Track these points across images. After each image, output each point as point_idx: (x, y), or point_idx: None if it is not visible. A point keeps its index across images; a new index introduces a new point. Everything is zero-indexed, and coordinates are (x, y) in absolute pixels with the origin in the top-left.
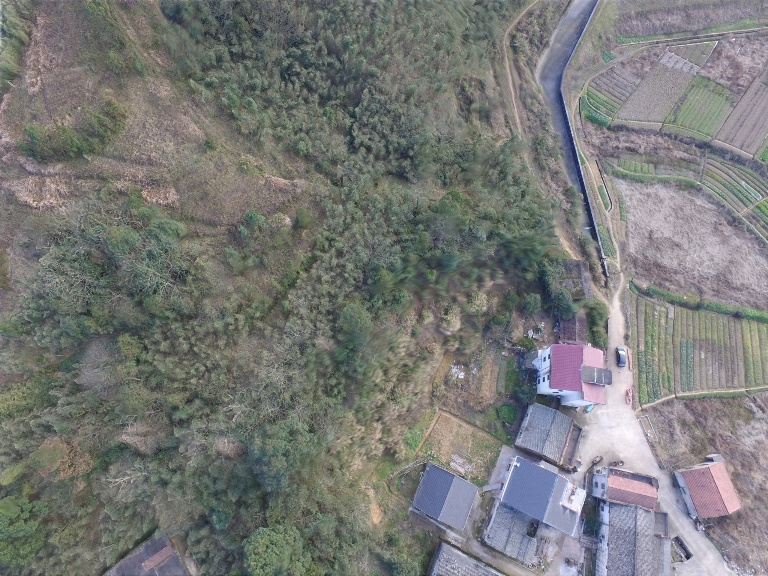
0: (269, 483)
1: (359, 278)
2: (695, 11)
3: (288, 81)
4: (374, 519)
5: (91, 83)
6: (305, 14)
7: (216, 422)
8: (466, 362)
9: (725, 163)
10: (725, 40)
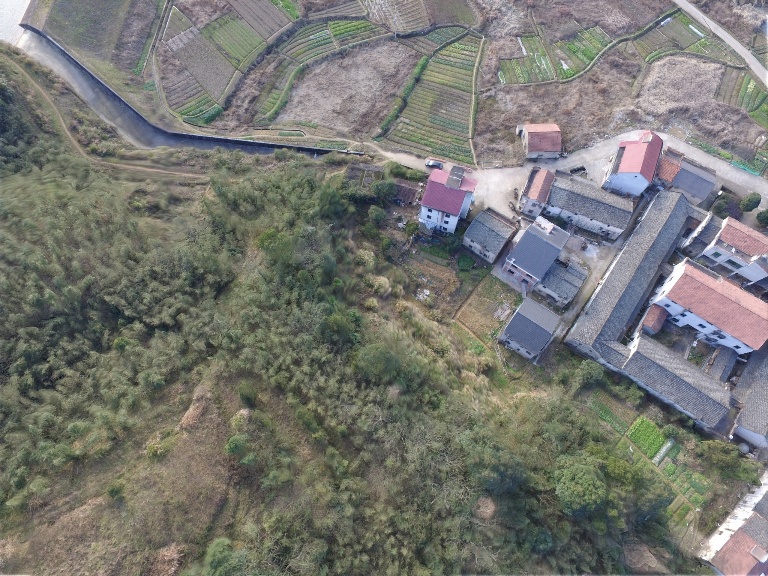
0: (520, 474)
1: (328, 349)
2: (136, 8)
3: (55, 383)
4: (543, 396)
5: None
6: None
7: (451, 531)
8: (416, 285)
9: (290, 42)
10: (175, 1)
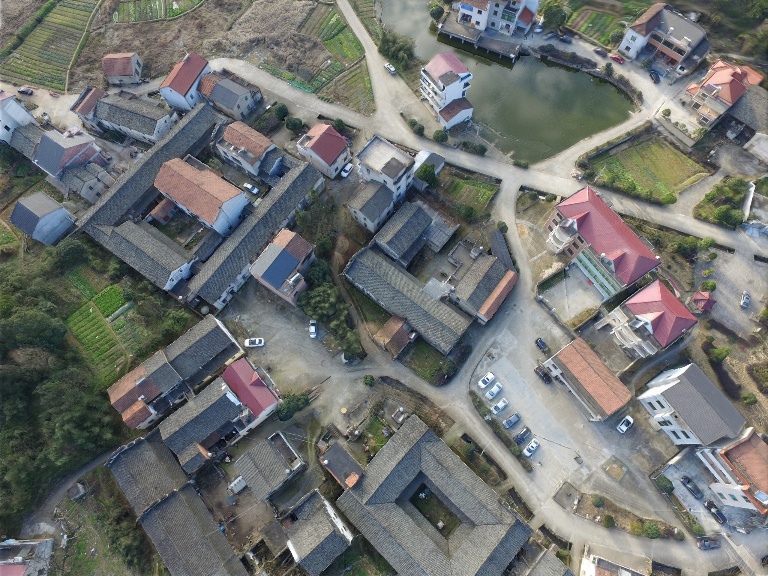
0: None
1: None
2: None
3: None
4: None
5: None
6: None
7: None
8: None
9: None
10: None
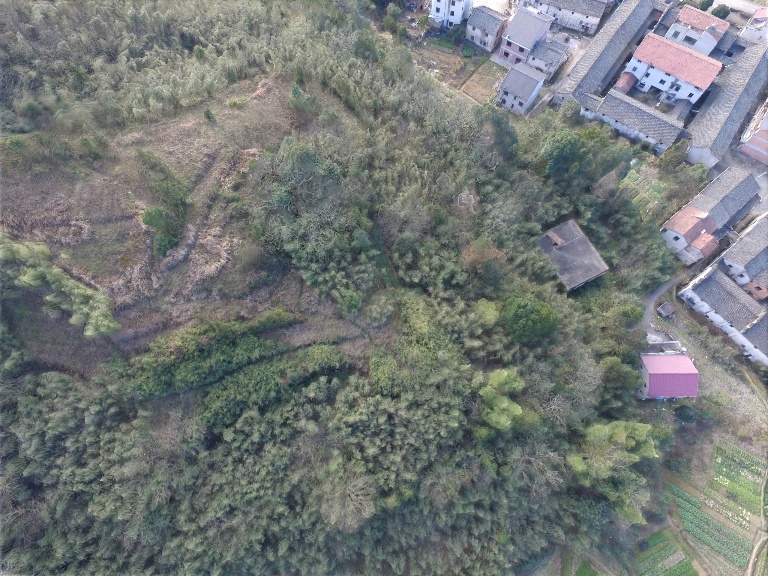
0: (513, 133)
1: None
2: None
3: None
4: None
5: (102, 178)
6: (89, 31)
7: (460, 170)
8: (427, 66)
9: None
10: None
